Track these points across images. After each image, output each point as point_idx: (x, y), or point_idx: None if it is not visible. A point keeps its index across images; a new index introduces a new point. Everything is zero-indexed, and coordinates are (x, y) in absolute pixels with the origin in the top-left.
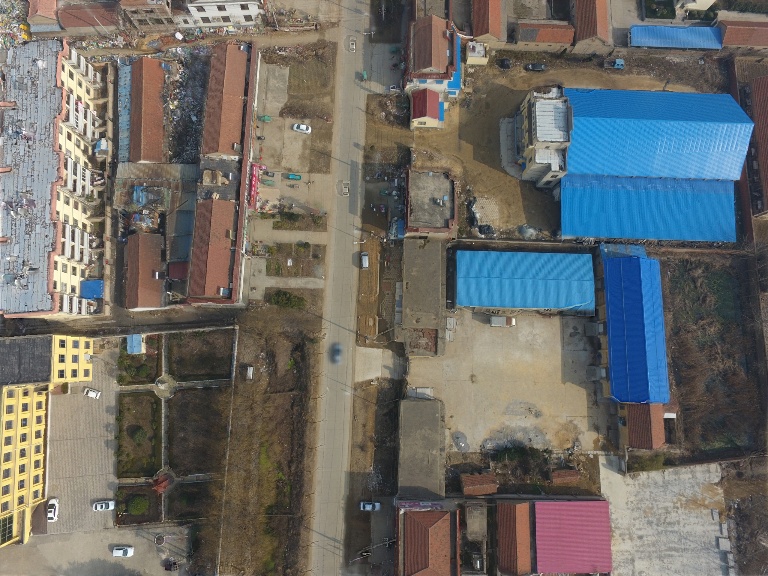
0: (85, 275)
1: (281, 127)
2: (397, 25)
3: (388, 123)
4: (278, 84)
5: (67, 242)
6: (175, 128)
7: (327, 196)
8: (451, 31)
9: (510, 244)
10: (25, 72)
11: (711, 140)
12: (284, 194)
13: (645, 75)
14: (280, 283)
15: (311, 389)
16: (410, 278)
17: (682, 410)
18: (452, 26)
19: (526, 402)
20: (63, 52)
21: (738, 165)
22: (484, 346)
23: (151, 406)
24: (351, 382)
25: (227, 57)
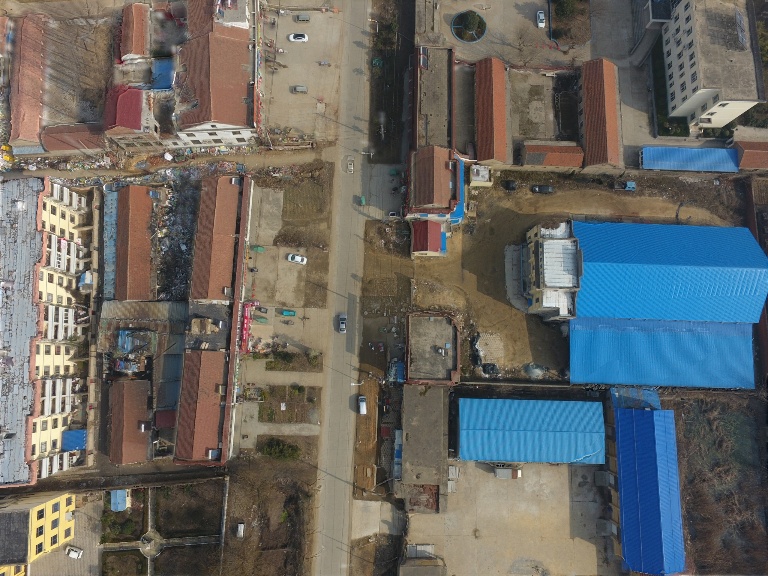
0: (67, 422)
1: (275, 257)
2: (397, 145)
3: (387, 251)
4: (272, 209)
5: (47, 399)
6: (163, 258)
7: (323, 333)
8: (454, 161)
9: (516, 387)
10: (4, 214)
11: (729, 285)
12: (278, 331)
13: (657, 197)
14: (273, 430)
15: (305, 548)
16: (410, 428)
17: (697, 568)
18: (455, 154)
19: (532, 560)
20: (44, 192)
21: (757, 309)
22: (488, 497)
23: (136, 565)
24: (347, 539)
25: (218, 193)
